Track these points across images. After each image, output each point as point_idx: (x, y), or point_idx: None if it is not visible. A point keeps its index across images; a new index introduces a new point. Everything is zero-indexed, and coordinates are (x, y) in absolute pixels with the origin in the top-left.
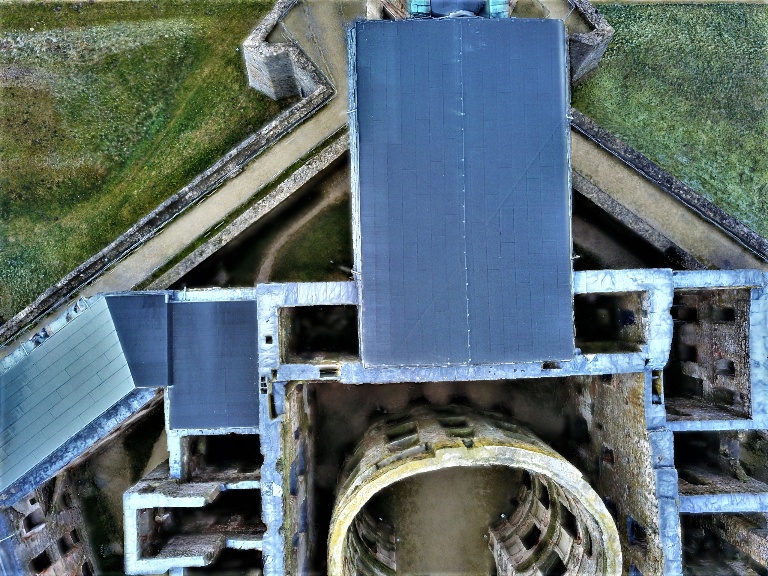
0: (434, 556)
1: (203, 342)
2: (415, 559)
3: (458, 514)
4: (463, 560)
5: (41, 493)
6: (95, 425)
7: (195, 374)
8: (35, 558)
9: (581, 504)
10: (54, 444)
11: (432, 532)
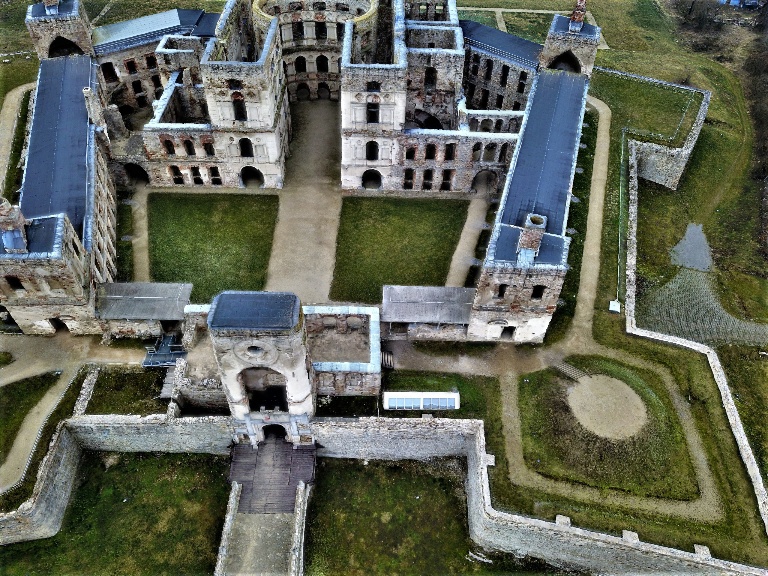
0: (313, 145)
1: (215, 20)
2: (302, 146)
3: (330, 132)
4: (330, 147)
5: (108, 91)
6: (156, 37)
7: (208, 25)
8: (100, 87)
9: (364, 3)
10: (136, 34)
11: (314, 137)
